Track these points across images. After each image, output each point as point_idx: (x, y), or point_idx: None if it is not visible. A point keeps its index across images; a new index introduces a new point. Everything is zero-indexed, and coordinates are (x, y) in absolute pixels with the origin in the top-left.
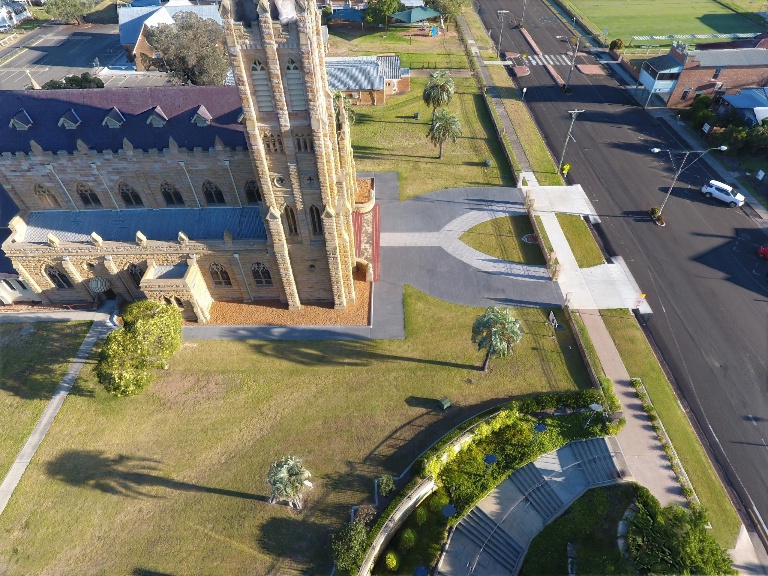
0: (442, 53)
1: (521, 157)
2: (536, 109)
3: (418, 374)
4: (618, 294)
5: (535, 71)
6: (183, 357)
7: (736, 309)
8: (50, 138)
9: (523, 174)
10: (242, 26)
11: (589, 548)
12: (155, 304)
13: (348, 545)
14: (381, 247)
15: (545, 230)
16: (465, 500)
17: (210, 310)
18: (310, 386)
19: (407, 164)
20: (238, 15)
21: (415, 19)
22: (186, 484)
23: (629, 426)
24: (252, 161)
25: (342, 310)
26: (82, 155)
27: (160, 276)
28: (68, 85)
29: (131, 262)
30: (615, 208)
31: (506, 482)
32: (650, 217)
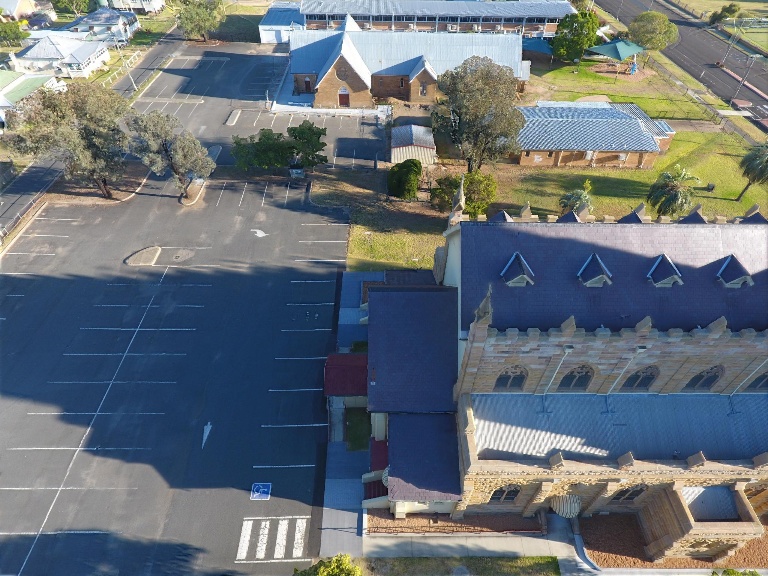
0: (662, 98)
1: None
2: None
3: None
4: None
5: None
6: None
7: None
8: (561, 300)
9: None
10: None
11: None
12: None
13: None
14: None
15: None
16: None
17: None
18: None
19: None
20: None
21: (624, 56)
22: None
23: None
24: None
25: None
26: (636, 337)
27: (690, 505)
28: (292, 138)
29: (645, 483)
30: None
31: None
32: None
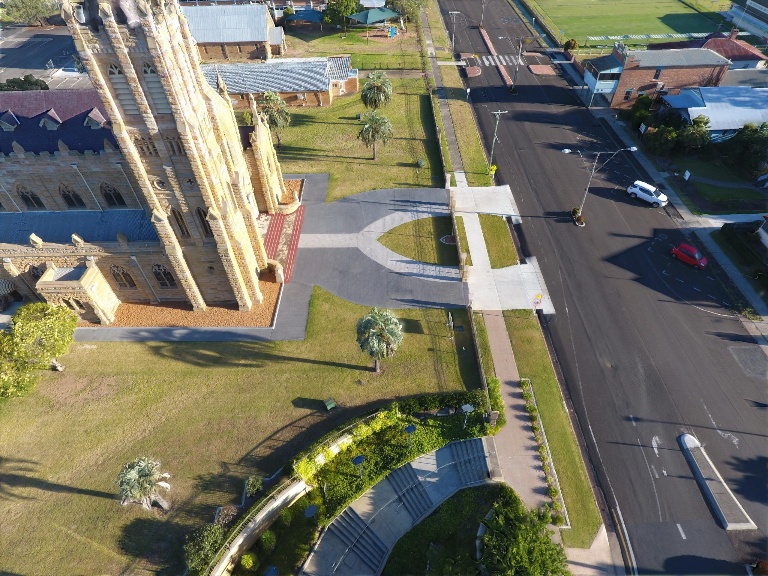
0: (397, 54)
1: (456, 158)
2: (480, 110)
3: (310, 375)
4: (525, 295)
5: (486, 72)
6: (80, 359)
7: (638, 309)
8: None
9: (450, 175)
10: (89, 30)
11: (449, 548)
12: (48, 306)
13: (199, 546)
14: (298, 248)
15: (465, 231)
16: (338, 501)
17: (116, 312)
18: (201, 387)
19: (340, 165)
20: (89, 19)
21: (371, 20)
22: (59, 485)
23: (509, 426)
24: (128, 164)
25: (247, 311)
26: None
27: (60, 278)
28: (10, 87)
29: (31, 264)
30: (539, 209)
31: (383, 483)
32: (571, 218)
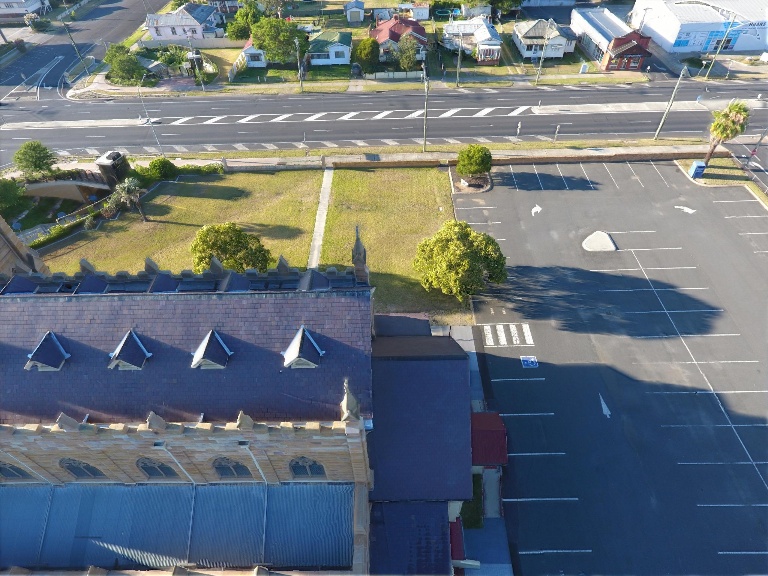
0: None
1: None
2: None
3: None
4: None
5: None
6: None
7: None
8: None
9: None
10: None
11: (5, 218)
12: None
13: None
14: None
15: None
16: None
17: None
18: None
19: None
20: None
21: None
22: None
23: None
24: None
25: None
26: None
27: None
28: None
29: None
30: None
31: None
32: None
